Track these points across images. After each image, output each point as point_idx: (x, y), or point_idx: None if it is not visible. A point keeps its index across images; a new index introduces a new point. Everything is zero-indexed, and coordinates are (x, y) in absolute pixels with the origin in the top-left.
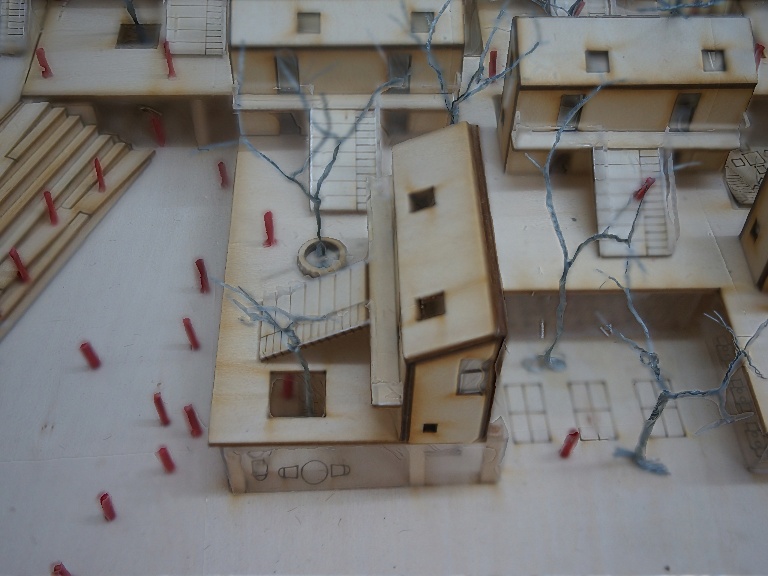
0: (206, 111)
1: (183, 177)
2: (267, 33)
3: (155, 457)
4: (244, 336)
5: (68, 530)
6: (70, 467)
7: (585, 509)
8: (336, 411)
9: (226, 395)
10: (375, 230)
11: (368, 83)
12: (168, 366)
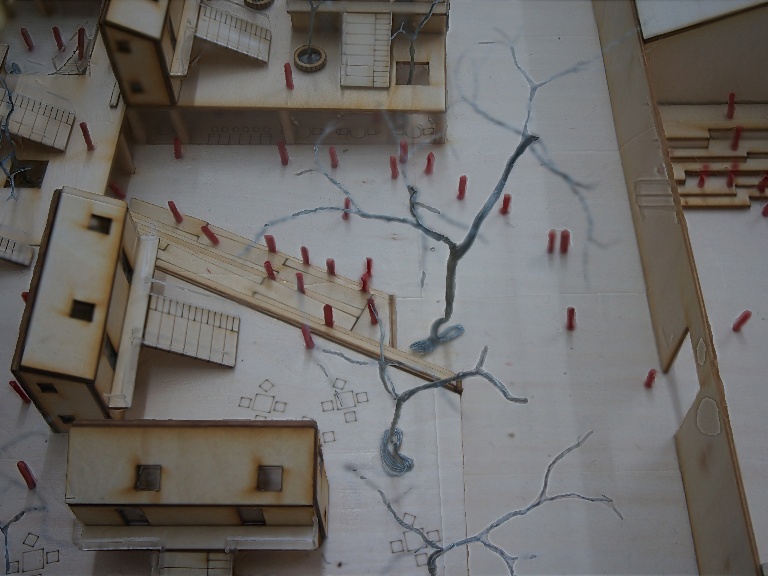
0: (125, 139)
1: (163, 182)
2: (154, 17)
3: (419, 180)
4: (369, 97)
5: (469, 217)
6: (425, 222)
7: (457, 4)
8: (425, 58)
9: (413, 103)
10: (321, 6)
11: (180, 0)
12: (349, 179)
